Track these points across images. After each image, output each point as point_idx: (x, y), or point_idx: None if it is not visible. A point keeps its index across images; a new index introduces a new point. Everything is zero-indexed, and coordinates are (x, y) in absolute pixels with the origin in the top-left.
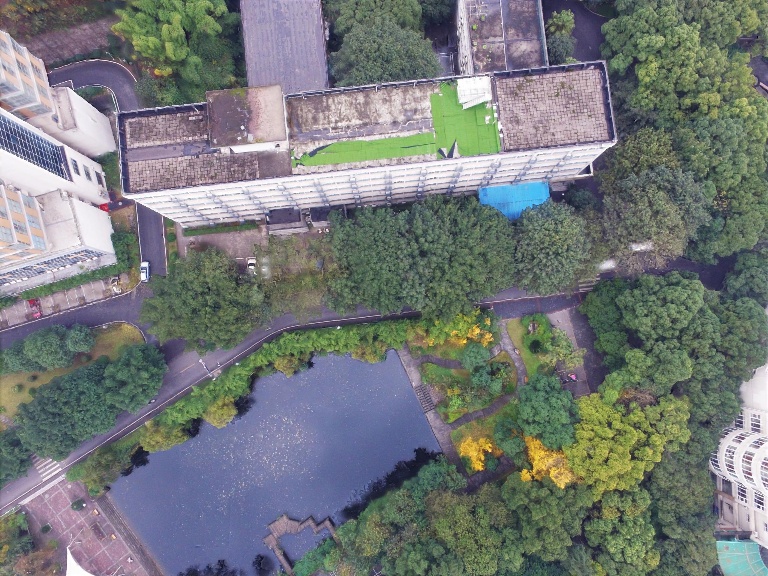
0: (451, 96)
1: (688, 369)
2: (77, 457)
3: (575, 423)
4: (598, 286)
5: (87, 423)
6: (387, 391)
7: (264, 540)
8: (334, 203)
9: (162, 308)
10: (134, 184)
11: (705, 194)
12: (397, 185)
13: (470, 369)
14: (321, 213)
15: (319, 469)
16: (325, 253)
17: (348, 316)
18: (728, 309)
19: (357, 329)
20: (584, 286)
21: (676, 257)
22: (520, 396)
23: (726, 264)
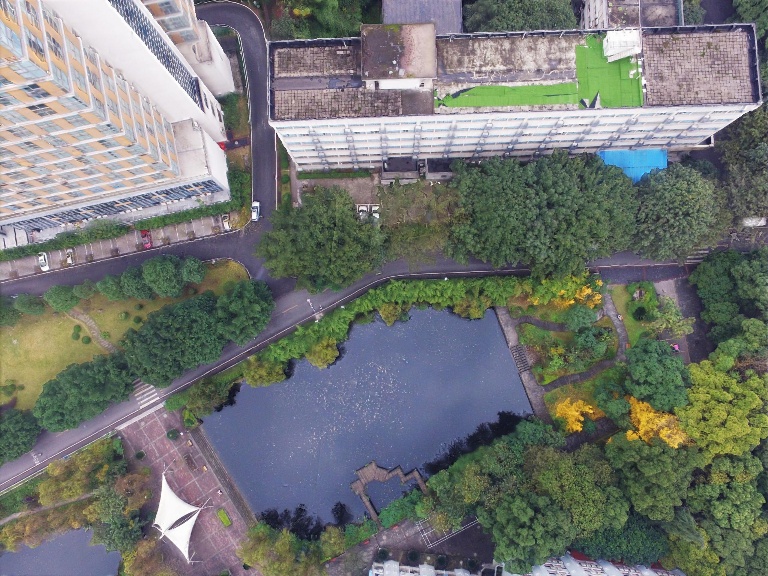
0: (596, 49)
1: None
2: (175, 388)
3: (686, 388)
4: (711, 257)
5: (196, 351)
6: (483, 348)
7: (351, 485)
8: (452, 155)
9: (285, 241)
10: (279, 112)
11: None
12: (524, 138)
13: (576, 329)
14: (438, 164)
15: (410, 420)
16: (451, 198)
17: (453, 270)
18: None
19: (463, 282)
20: (692, 258)
21: None
22: (628, 358)
23: None
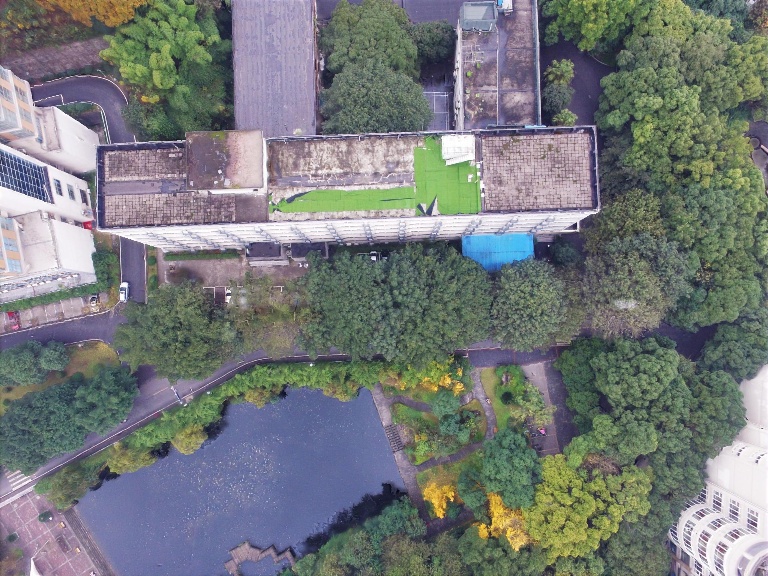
0: (435, 151)
1: (653, 443)
2: (47, 470)
3: (537, 483)
4: (574, 344)
5: (56, 442)
6: (357, 428)
7: (225, 565)
8: (315, 240)
9: (134, 338)
10: (110, 218)
11: (688, 266)
12: (377, 231)
13: (439, 417)
14: (302, 249)
15: (284, 500)
16: (299, 296)
17: None
18: (702, 381)
19: (330, 367)
20: None
21: (652, 328)
22: (485, 450)
23: (706, 332)
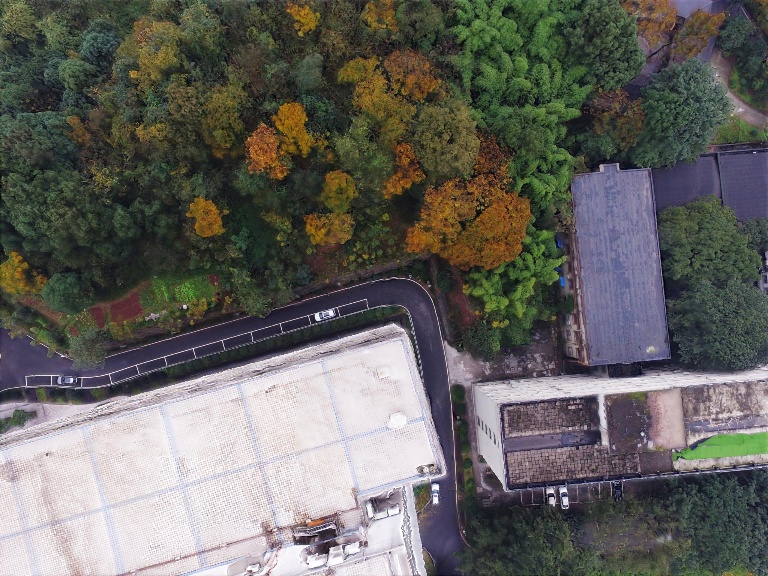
0: None
1: None
2: None
3: None
4: None
5: None
6: None
7: None
8: None
9: (499, 570)
10: (514, 476)
11: None
12: None
13: None
14: None
15: None
16: (673, 523)
17: None
18: None
19: None
20: None
21: None
22: None
23: None
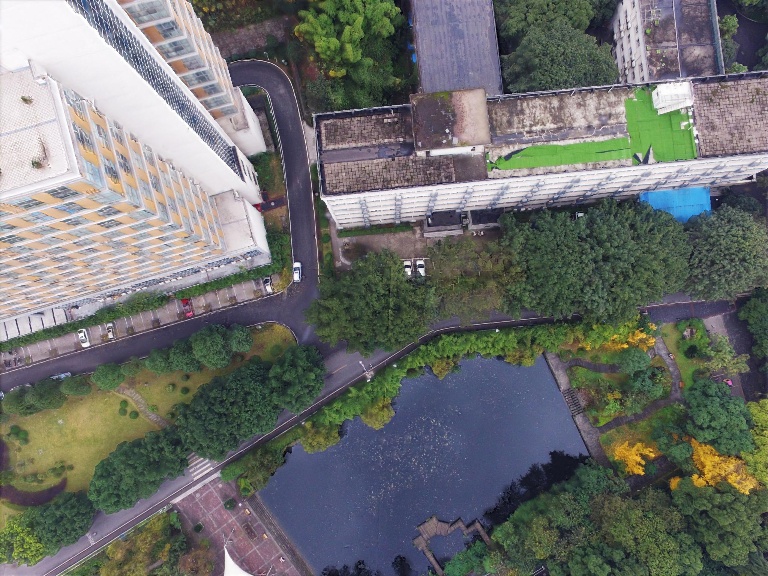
0: (645, 101)
1: None
2: (228, 456)
3: None
4: (760, 292)
5: (252, 423)
6: (535, 394)
7: (414, 541)
8: (496, 206)
9: (338, 310)
10: (330, 186)
11: None
12: (571, 189)
13: (631, 373)
14: (481, 216)
15: (467, 471)
16: (505, 257)
17: (501, 319)
18: None
19: (515, 332)
20: None
21: None
22: (687, 401)
23: None
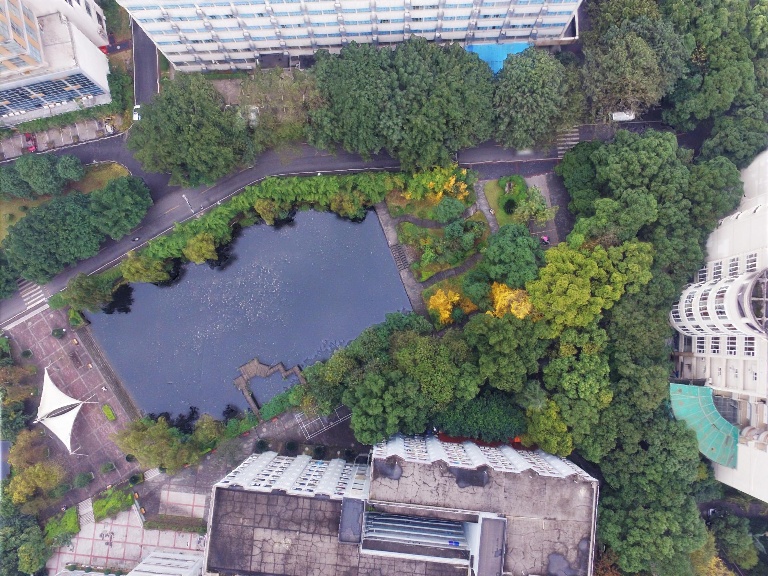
0: None
1: (653, 210)
2: (61, 288)
3: (541, 267)
4: (575, 147)
5: (71, 243)
6: (363, 248)
7: (234, 381)
8: None
9: (148, 129)
10: None
11: (684, 45)
12: (383, 26)
13: (444, 220)
14: (310, 61)
15: (292, 318)
16: (308, 82)
17: (330, 168)
18: None
19: (337, 177)
20: (563, 153)
21: (650, 102)
22: None
23: (704, 132)
